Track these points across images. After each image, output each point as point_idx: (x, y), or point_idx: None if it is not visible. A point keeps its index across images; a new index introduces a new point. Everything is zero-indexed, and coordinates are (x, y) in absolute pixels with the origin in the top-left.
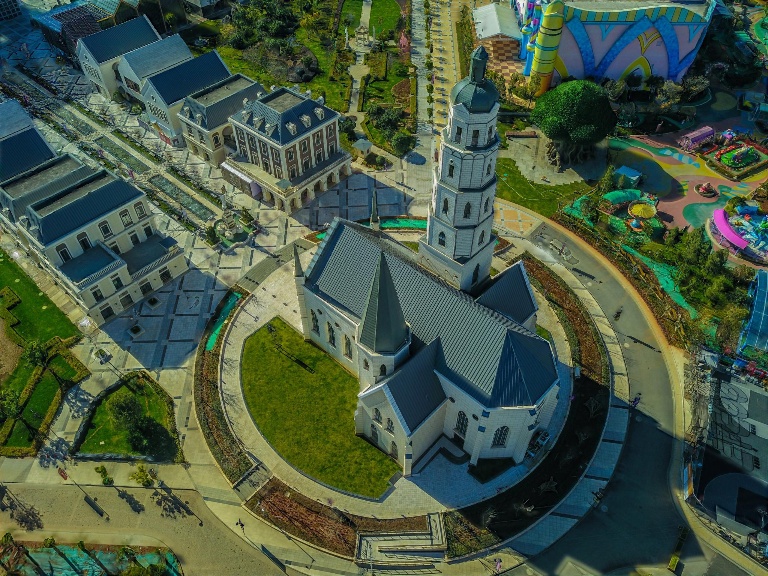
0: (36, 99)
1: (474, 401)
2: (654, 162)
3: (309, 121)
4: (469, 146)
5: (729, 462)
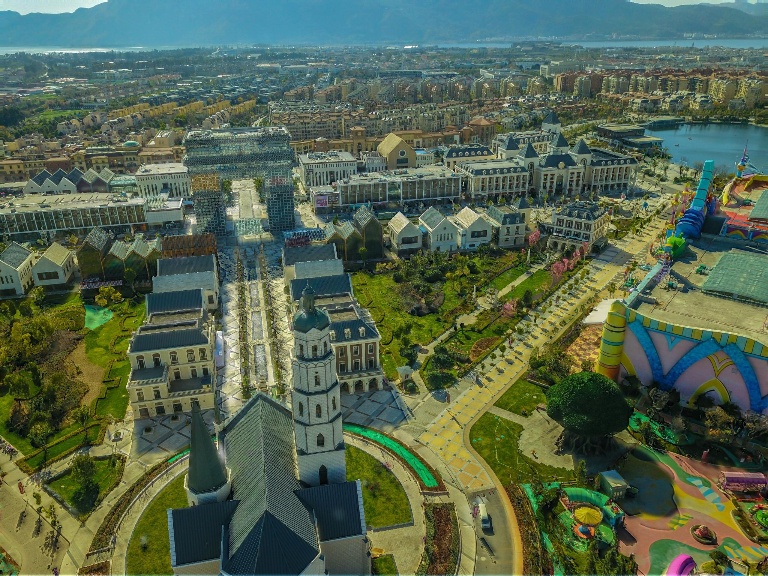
0: (249, 279)
1: None
2: (670, 484)
3: (349, 334)
4: (298, 355)
5: None
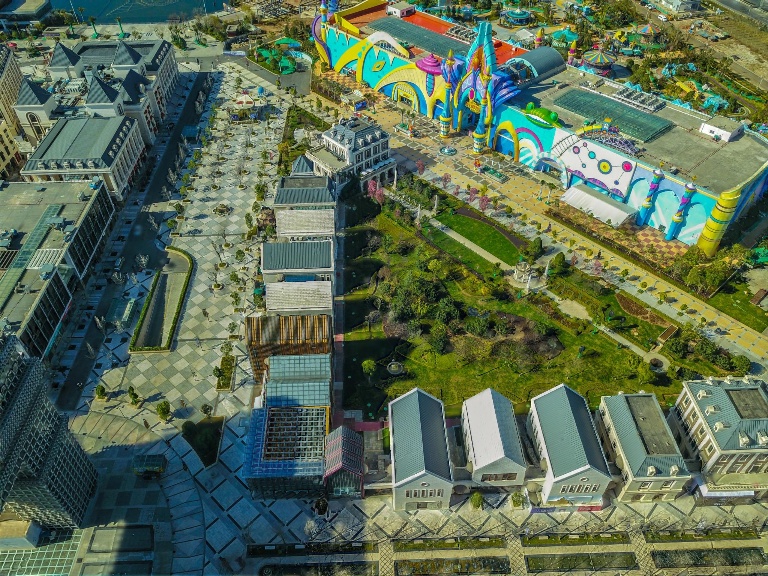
0: None
1: None
2: None
3: None
4: None
5: None
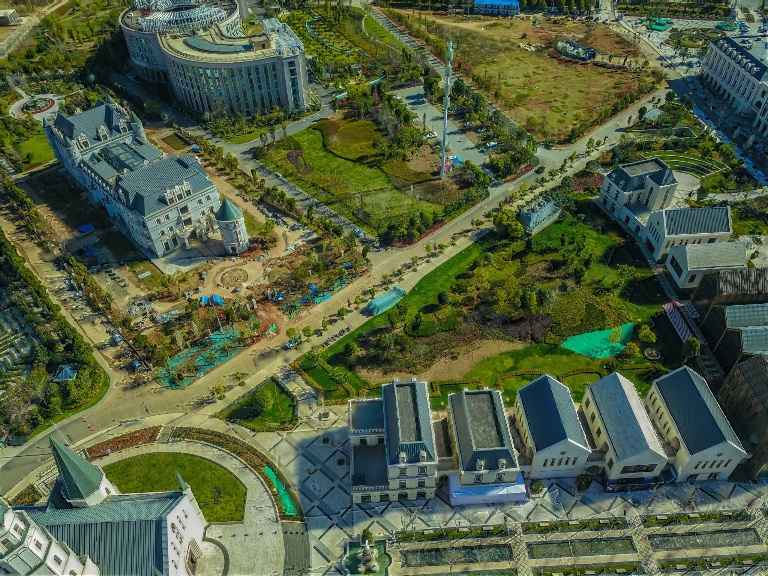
0: None
1: (11, 506)
2: None
3: None
4: None
5: None
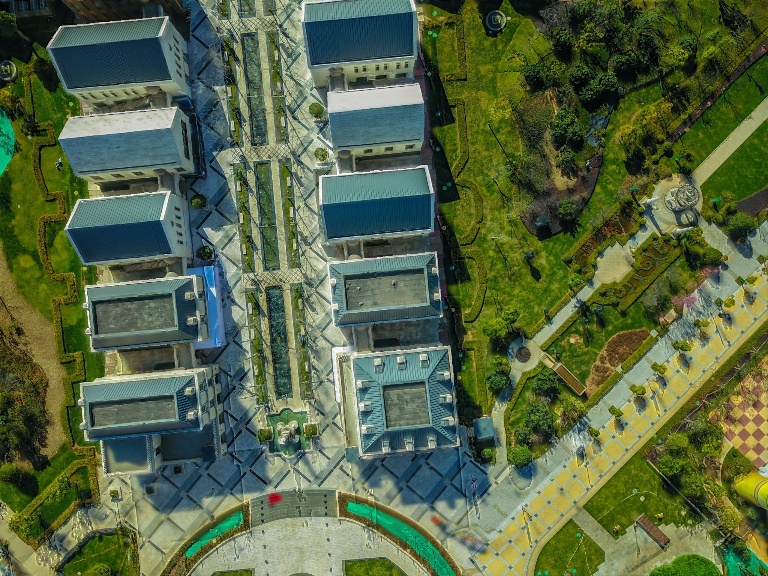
0: (240, 8)
1: None
2: None
3: None
4: None
5: None
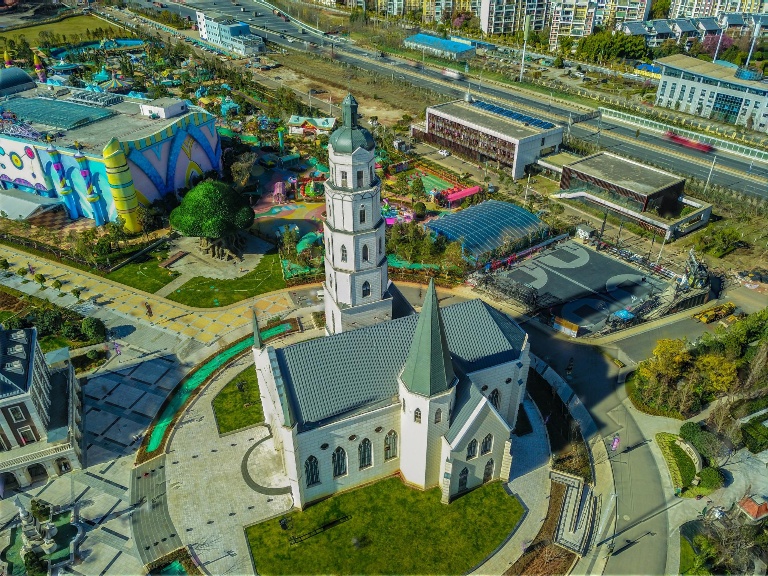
0: None
1: (509, 363)
2: (280, 219)
3: None
4: (370, 184)
5: (554, 308)
